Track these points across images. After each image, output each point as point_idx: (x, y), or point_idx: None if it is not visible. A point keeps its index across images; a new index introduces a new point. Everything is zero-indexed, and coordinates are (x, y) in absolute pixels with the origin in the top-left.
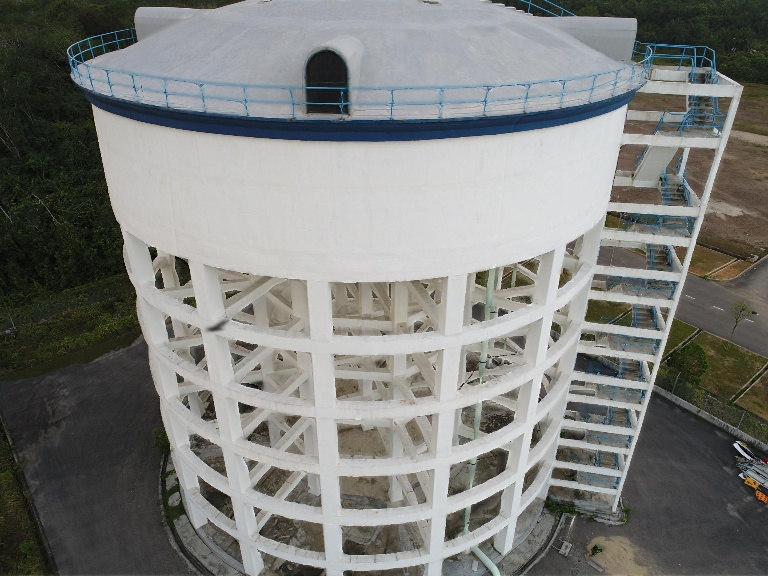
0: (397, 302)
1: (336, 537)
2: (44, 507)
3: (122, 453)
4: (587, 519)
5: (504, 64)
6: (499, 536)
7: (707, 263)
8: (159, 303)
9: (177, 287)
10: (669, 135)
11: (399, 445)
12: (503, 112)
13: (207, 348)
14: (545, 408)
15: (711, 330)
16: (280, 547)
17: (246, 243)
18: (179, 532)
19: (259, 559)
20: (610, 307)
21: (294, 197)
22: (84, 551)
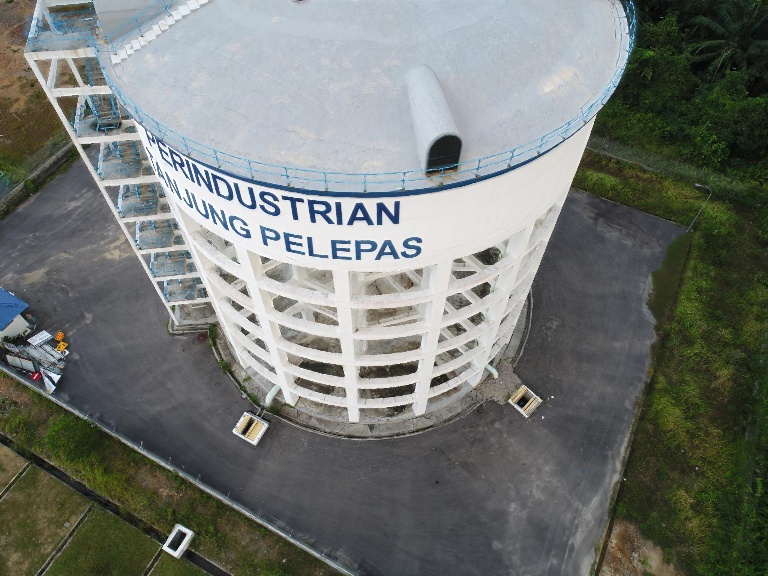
0: None
1: None
2: None
3: None
4: None
5: None
6: None
7: None
8: None
9: None
10: None
11: None
12: None
13: None
14: None
15: None
16: None
17: None
18: None
19: None
20: None
21: None
22: None
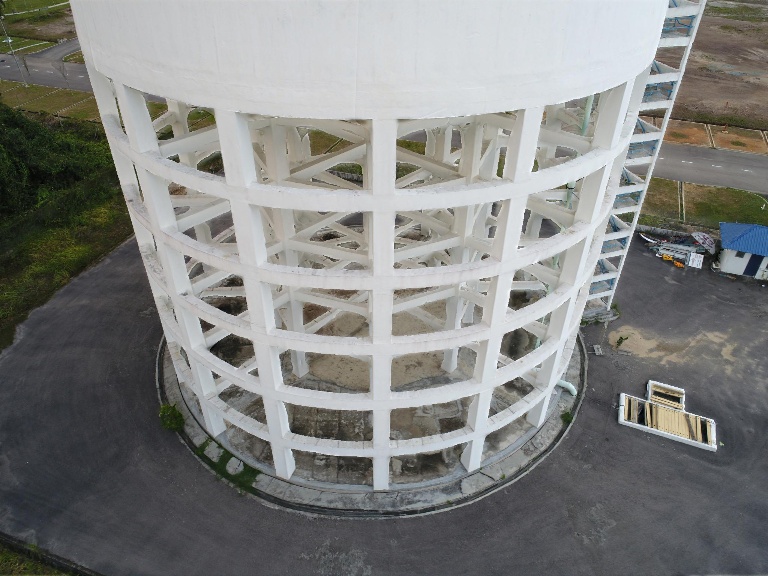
0: (475, 153)
1: (489, 402)
2: (70, 550)
3: (121, 453)
4: (595, 323)
5: None
6: None
7: None
8: (297, 199)
9: (198, 208)
10: None
11: (460, 311)
12: None
13: (379, 234)
14: None
15: None
16: (425, 441)
17: (465, 75)
18: (269, 492)
19: None
20: None
21: (533, 2)
22: (171, 564)
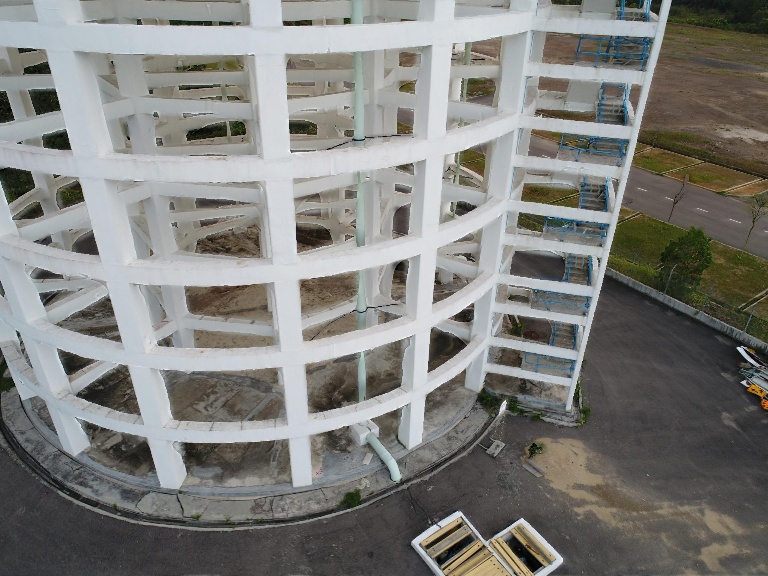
0: None
1: (149, 387)
2: None
3: None
4: (531, 417)
5: None
6: (403, 422)
7: (726, 180)
8: None
9: None
10: None
11: None
12: None
13: None
14: (455, 226)
15: (723, 240)
16: (89, 407)
17: None
18: (2, 404)
19: (79, 432)
20: None
21: None
22: None
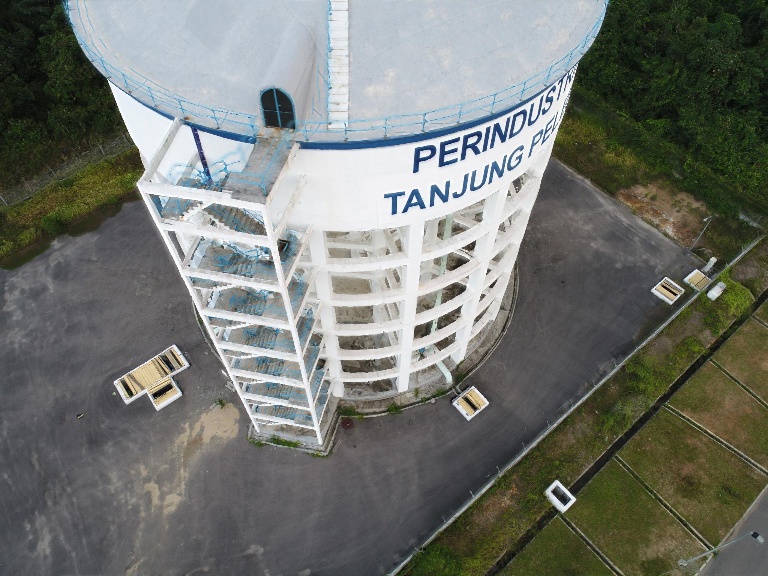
0: None
1: None
2: None
3: None
4: None
5: (137, 3)
6: None
7: None
8: None
9: None
10: (180, 182)
11: None
12: (76, 17)
13: None
14: None
15: None
16: None
17: None
18: None
19: None
20: (637, 559)
21: None
22: None
